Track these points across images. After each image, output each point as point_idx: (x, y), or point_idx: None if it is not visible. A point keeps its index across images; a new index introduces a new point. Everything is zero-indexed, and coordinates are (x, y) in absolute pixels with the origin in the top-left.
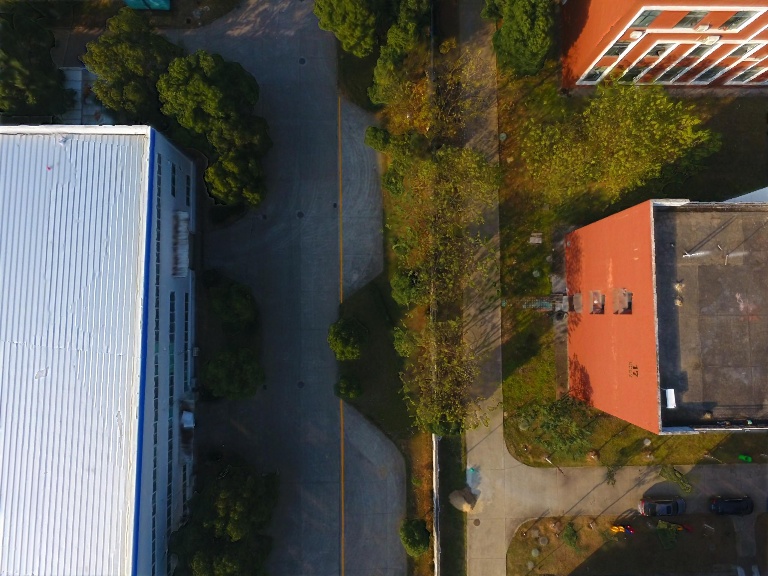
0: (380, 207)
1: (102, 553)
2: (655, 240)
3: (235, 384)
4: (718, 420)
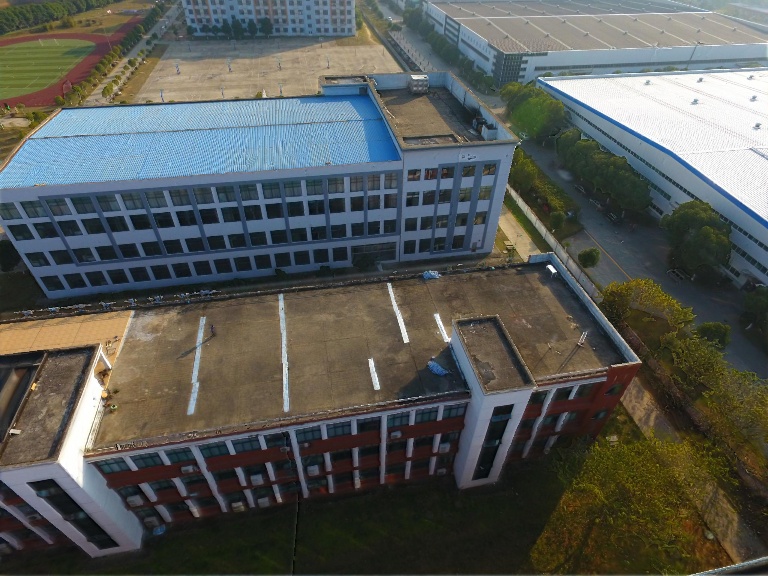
0: (759, 449)
1: (766, 212)
2: (609, 350)
3: (767, 290)
4: (511, 268)
